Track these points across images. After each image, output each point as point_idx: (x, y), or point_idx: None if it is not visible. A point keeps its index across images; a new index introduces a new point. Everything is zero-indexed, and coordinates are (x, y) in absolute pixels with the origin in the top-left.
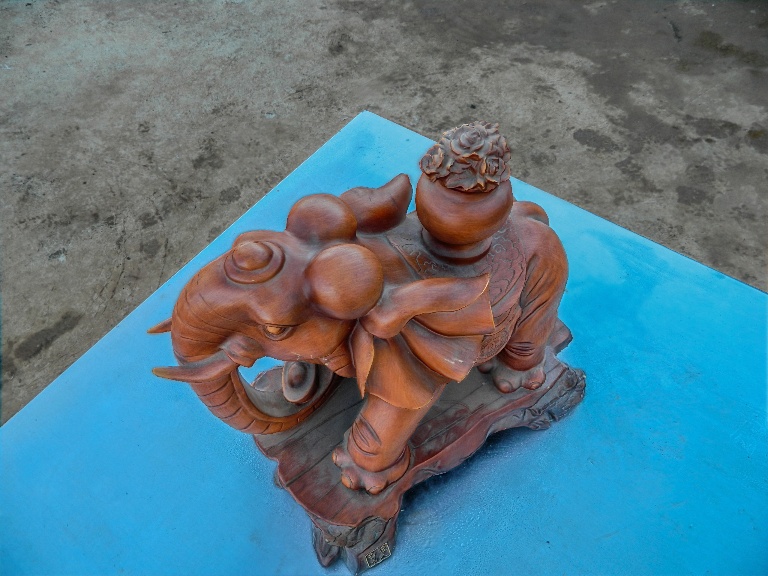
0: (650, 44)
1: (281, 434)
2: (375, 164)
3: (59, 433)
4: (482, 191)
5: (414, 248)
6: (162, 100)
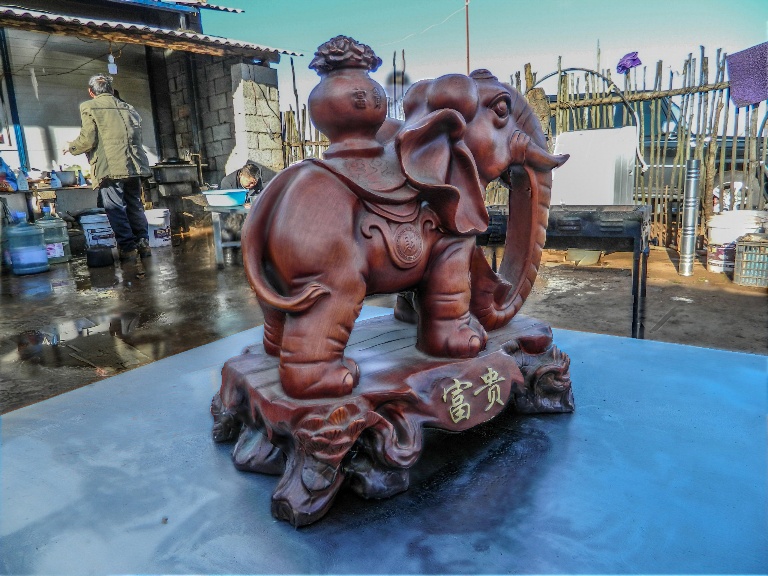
0: None
1: None
2: None
3: (758, 386)
4: None
5: (389, 146)
6: None
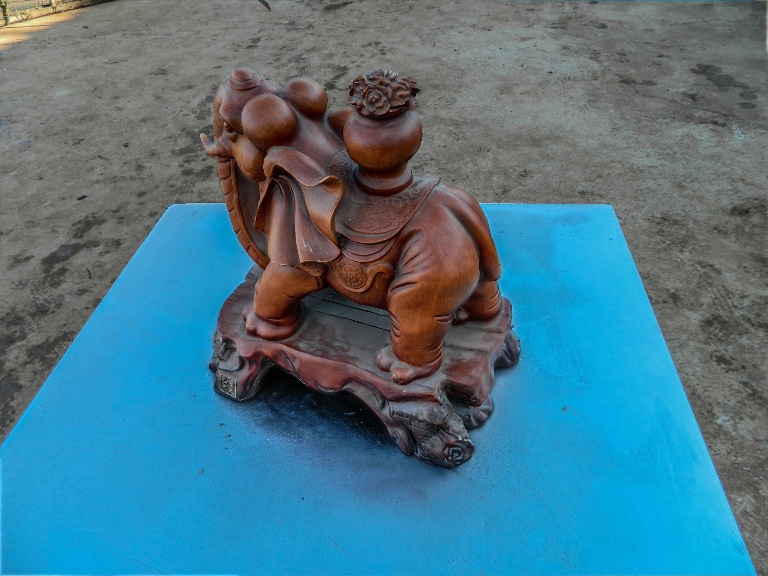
0: None
1: None
2: (561, 235)
3: None
4: None
5: (350, 162)
6: (557, 165)
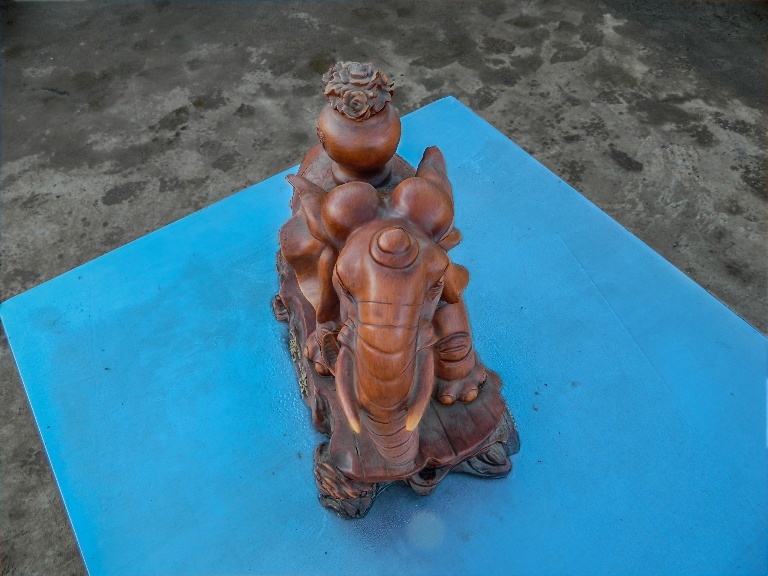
0: (53, 112)
1: None
2: (90, 316)
3: None
4: None
5: None
6: None
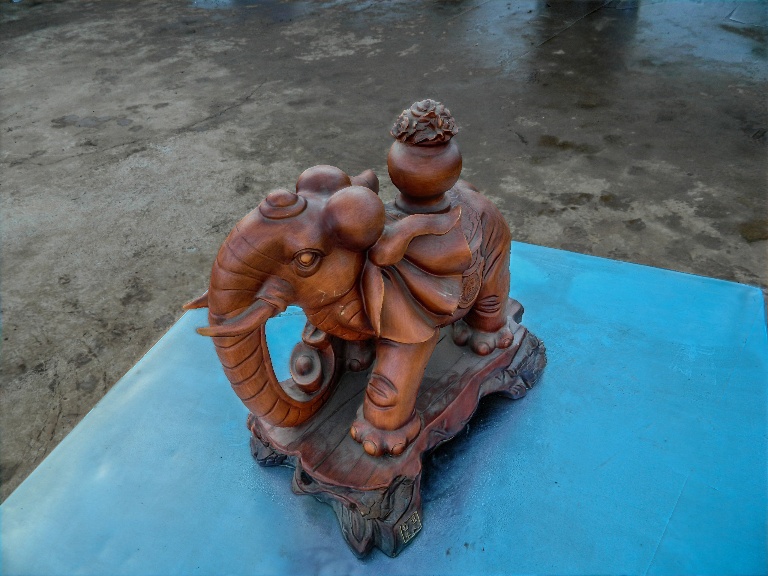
0: (505, 149)
1: (296, 431)
2: None
3: (51, 514)
4: (442, 141)
5: (393, 212)
6: (80, 254)
